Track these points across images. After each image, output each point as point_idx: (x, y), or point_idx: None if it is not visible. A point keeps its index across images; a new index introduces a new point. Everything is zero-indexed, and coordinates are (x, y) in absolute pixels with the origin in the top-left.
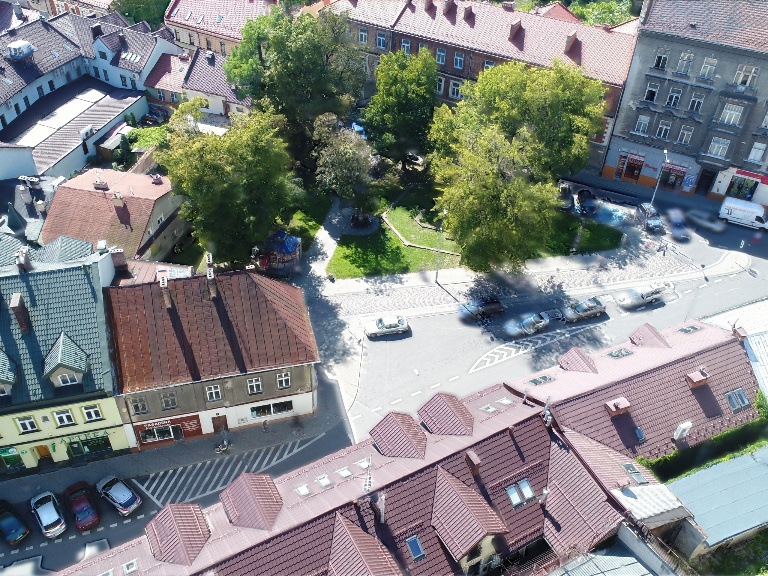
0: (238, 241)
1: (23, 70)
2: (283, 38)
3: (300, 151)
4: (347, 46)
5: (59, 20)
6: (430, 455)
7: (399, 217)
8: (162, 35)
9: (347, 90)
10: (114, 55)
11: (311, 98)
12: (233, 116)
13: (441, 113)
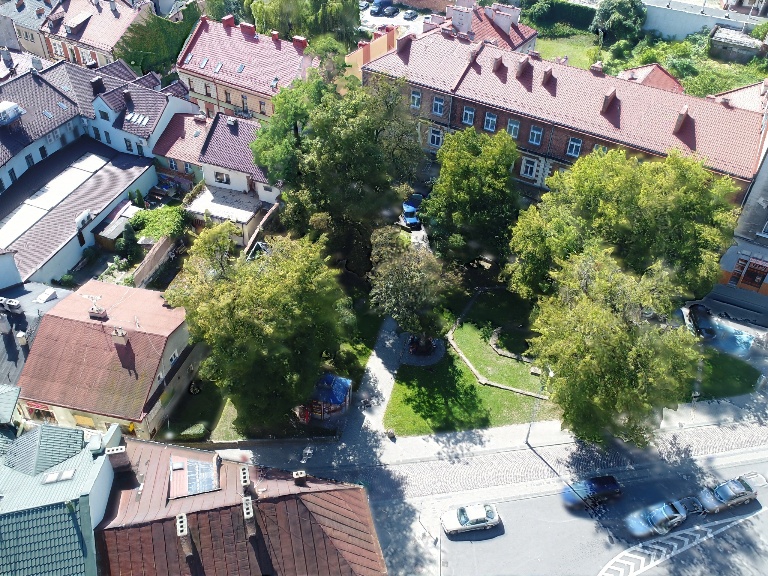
0: (275, 399)
1: (8, 137)
2: (329, 121)
3: (345, 252)
4: (402, 120)
5: (53, 71)
6: None
7: (469, 339)
8: (174, 90)
9: (401, 174)
10: (117, 116)
11: (362, 193)
12: (271, 242)
13: (528, 218)
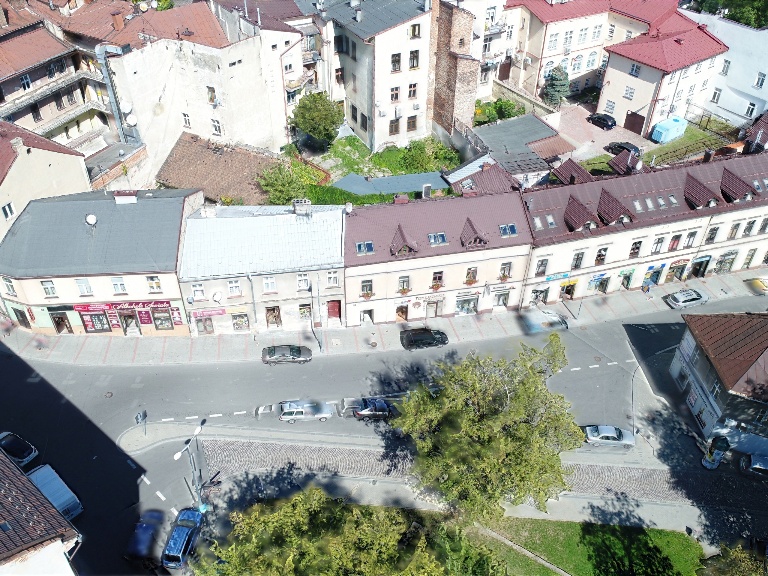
0: None
1: None
2: None
3: None
4: None
5: None
6: (599, 190)
7: None
8: None
9: None
10: None
11: None
12: None
13: None
